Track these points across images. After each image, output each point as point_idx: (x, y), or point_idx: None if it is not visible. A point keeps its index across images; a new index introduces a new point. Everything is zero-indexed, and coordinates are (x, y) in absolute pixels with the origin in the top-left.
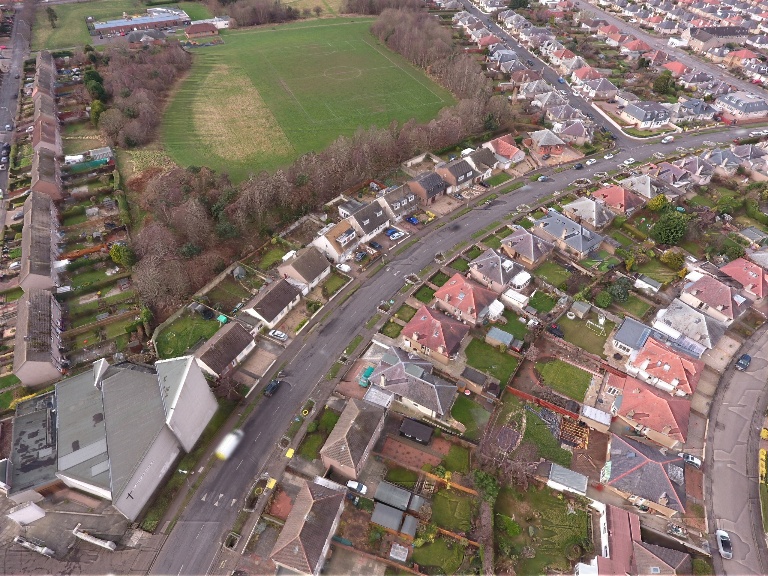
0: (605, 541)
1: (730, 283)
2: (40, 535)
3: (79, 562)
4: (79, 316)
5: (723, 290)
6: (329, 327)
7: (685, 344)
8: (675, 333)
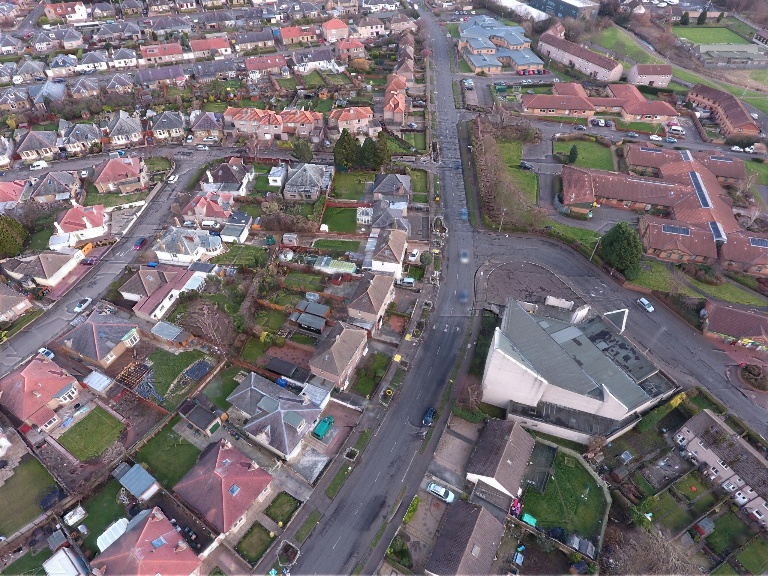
0: None
1: None
2: (563, 313)
3: (525, 301)
4: (748, 537)
5: None
6: (373, 513)
7: None
8: None
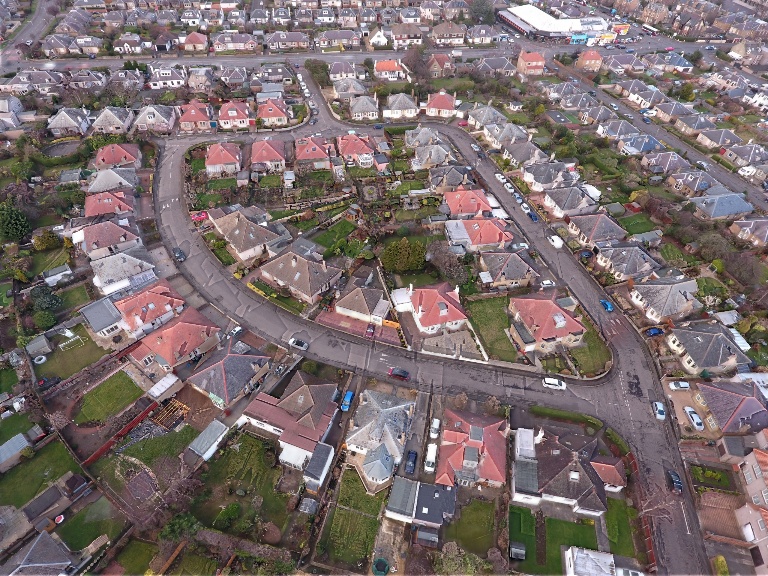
0: (270, 428)
1: (105, 219)
2: None
3: None
4: None
5: (107, 227)
6: None
7: (139, 281)
8: (124, 282)
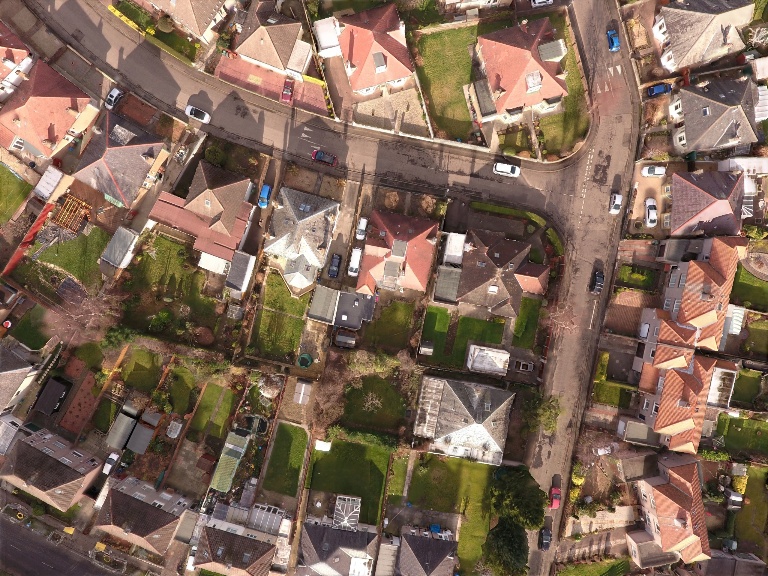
0: None
1: None
2: None
3: None
4: None
5: None
6: None
7: None
8: None
